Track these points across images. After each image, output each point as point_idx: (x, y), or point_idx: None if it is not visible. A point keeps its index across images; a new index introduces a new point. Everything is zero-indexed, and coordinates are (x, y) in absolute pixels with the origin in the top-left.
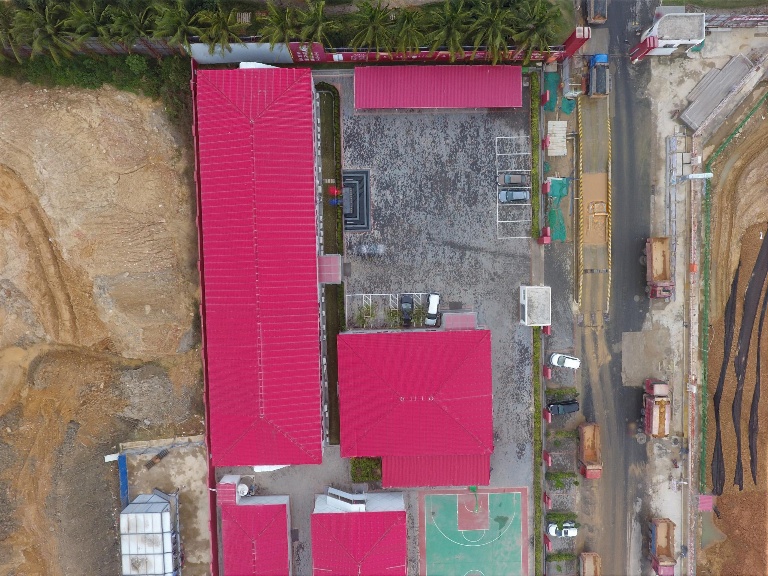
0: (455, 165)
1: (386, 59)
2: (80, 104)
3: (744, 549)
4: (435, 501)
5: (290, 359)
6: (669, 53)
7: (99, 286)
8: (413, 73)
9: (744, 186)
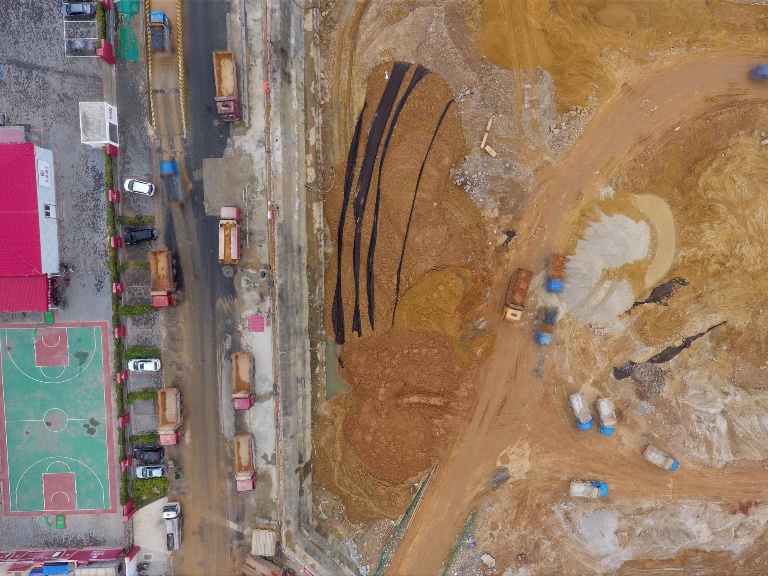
0: None
1: None
2: None
3: (364, 398)
4: (10, 335)
5: None
6: None
7: None
8: None
9: (364, 22)
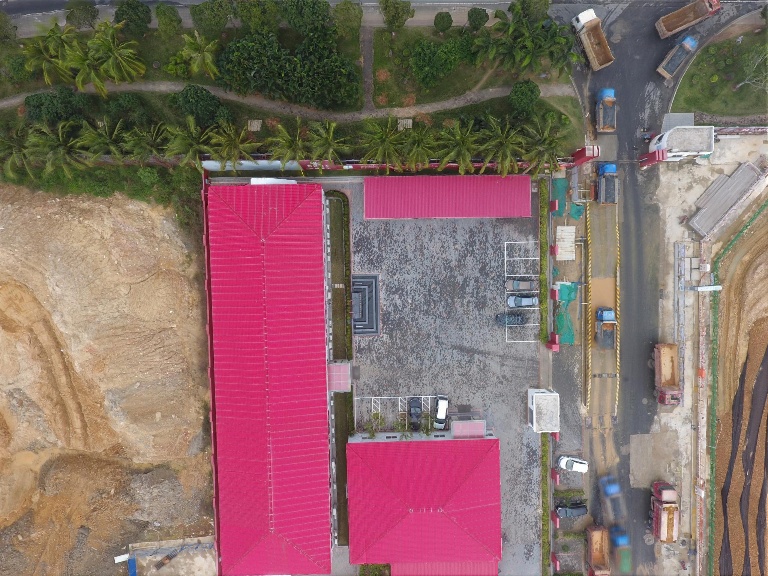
0: (464, 270)
1: (396, 172)
2: (92, 214)
3: None
4: None
5: (300, 472)
6: (678, 160)
7: (110, 400)
8: (423, 183)
9: (752, 281)
